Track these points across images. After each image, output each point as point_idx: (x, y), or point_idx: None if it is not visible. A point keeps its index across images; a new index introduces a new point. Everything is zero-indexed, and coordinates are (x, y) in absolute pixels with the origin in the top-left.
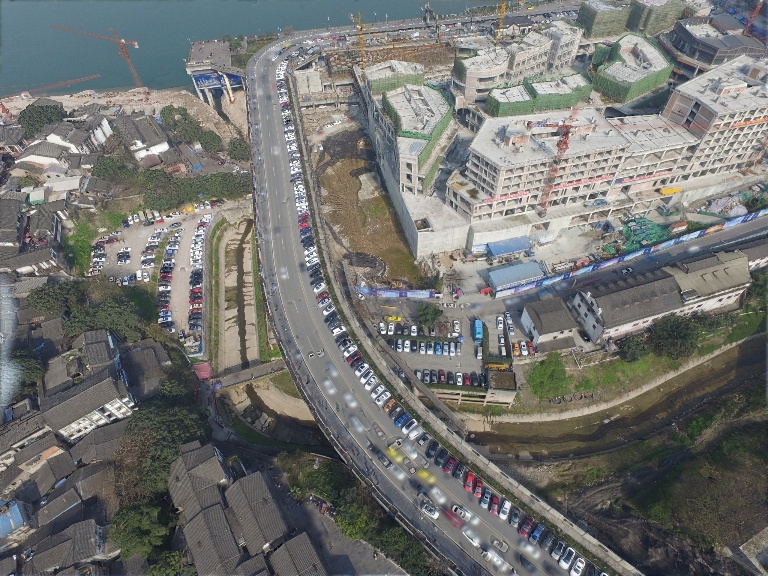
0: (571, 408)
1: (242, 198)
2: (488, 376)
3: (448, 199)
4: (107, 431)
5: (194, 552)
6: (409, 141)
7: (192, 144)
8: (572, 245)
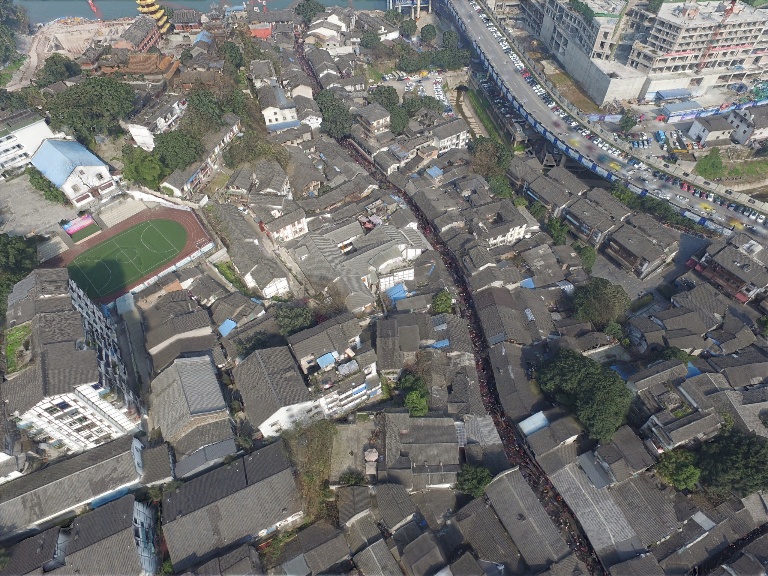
0: (726, 184)
1: (459, 70)
2: (675, 155)
3: (630, 60)
4: (460, 150)
5: (541, 193)
6: (604, 19)
7: (408, 38)
8: (716, 98)
